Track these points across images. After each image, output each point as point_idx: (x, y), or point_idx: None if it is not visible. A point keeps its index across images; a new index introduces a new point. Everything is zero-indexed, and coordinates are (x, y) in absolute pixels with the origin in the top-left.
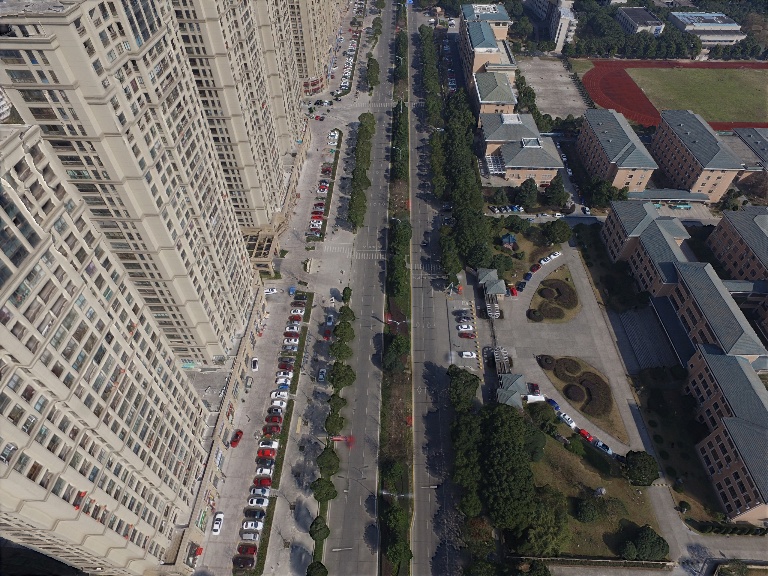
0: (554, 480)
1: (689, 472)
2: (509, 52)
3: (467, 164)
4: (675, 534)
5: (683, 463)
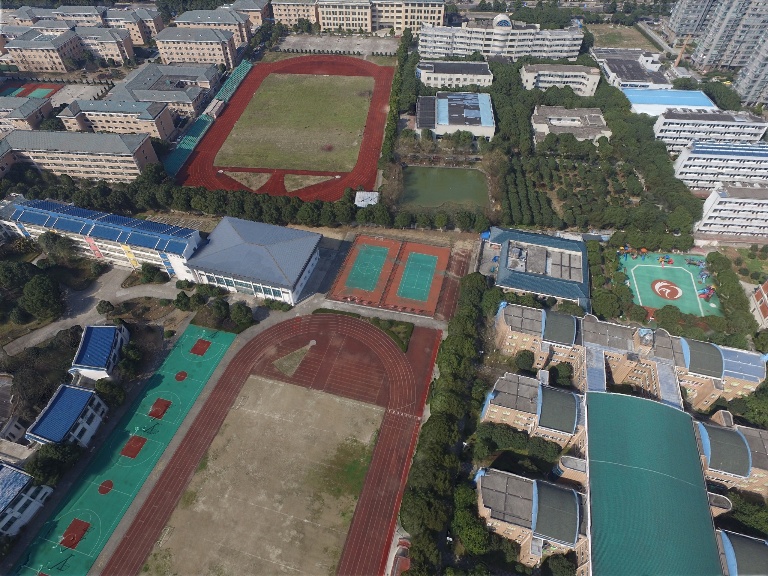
0: None
1: None
2: (342, 1)
3: (226, 0)
4: None
5: None
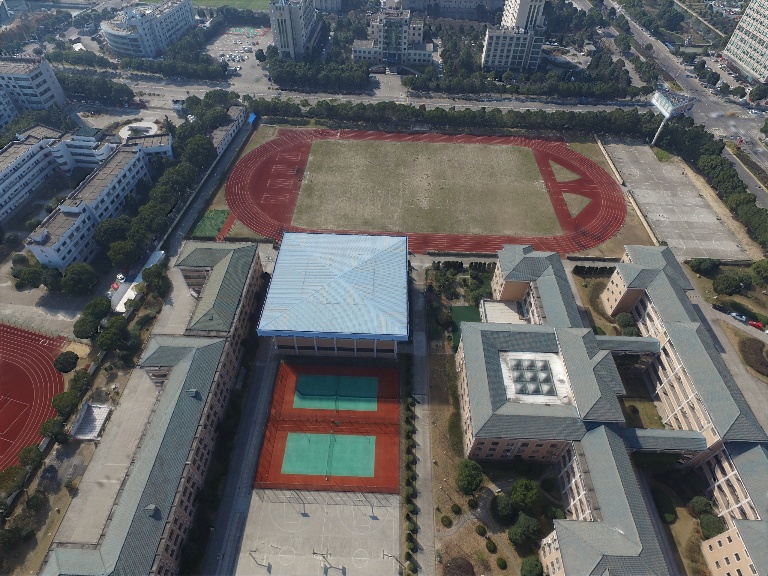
0: None
1: None
2: None
3: None
4: None
5: None
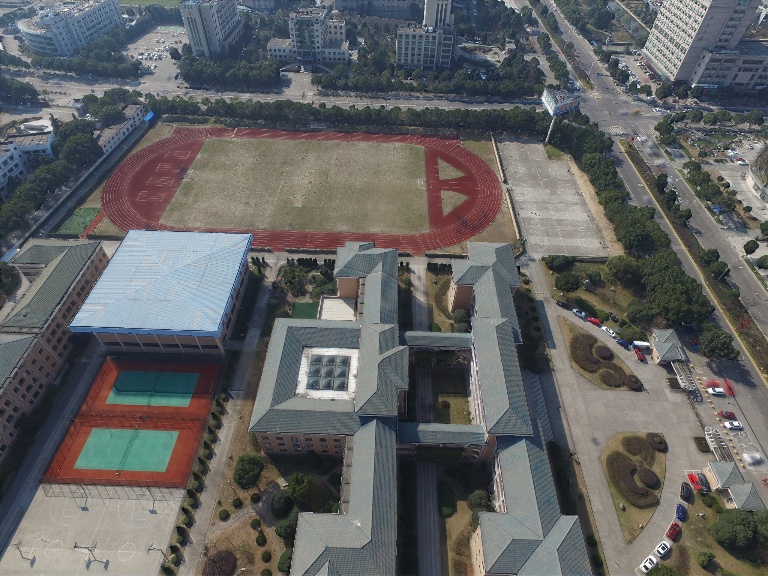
0: (615, 296)
1: (517, 299)
2: None
3: None
4: (535, 271)
5: (520, 304)
